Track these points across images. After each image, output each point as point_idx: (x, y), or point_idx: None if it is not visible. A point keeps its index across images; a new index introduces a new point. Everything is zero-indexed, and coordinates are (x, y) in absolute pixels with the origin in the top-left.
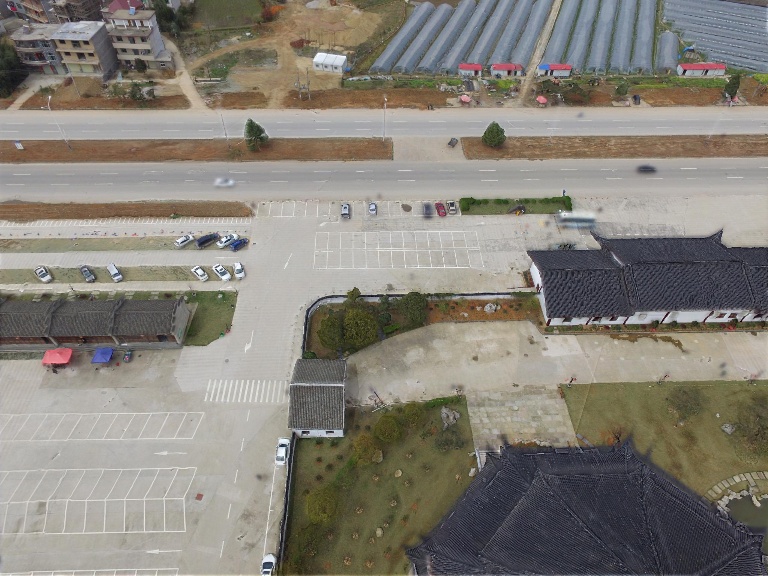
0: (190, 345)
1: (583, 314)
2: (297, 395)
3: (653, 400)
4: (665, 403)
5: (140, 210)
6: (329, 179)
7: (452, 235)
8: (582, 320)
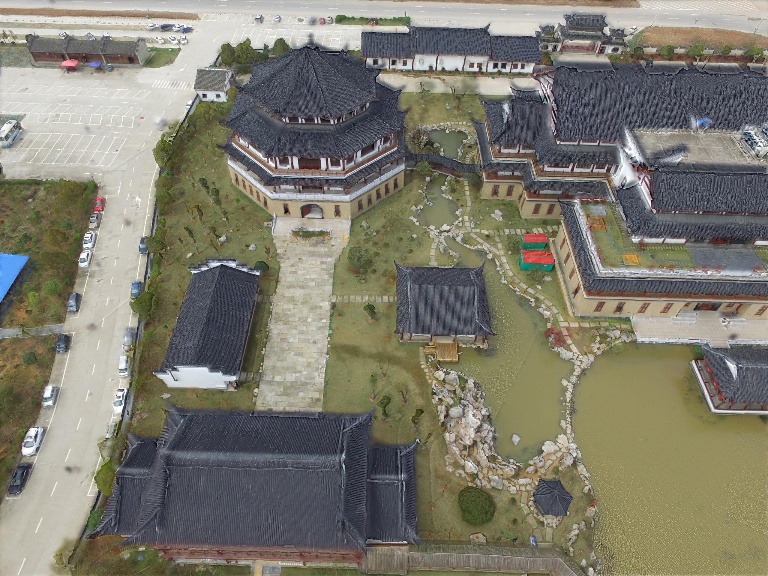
0: (148, 67)
1: (382, 56)
2: (201, 74)
3: (413, 98)
4: (419, 99)
5: (127, 14)
6: (254, 5)
7: (325, 33)
8: (385, 64)
